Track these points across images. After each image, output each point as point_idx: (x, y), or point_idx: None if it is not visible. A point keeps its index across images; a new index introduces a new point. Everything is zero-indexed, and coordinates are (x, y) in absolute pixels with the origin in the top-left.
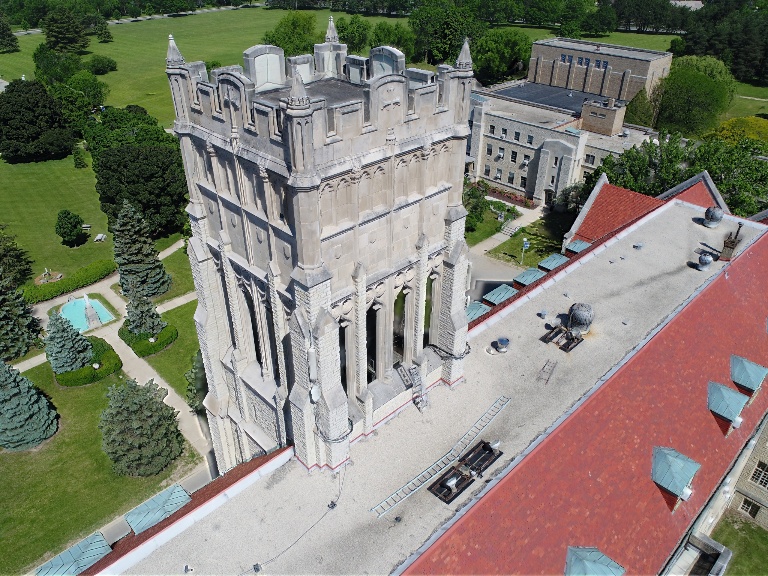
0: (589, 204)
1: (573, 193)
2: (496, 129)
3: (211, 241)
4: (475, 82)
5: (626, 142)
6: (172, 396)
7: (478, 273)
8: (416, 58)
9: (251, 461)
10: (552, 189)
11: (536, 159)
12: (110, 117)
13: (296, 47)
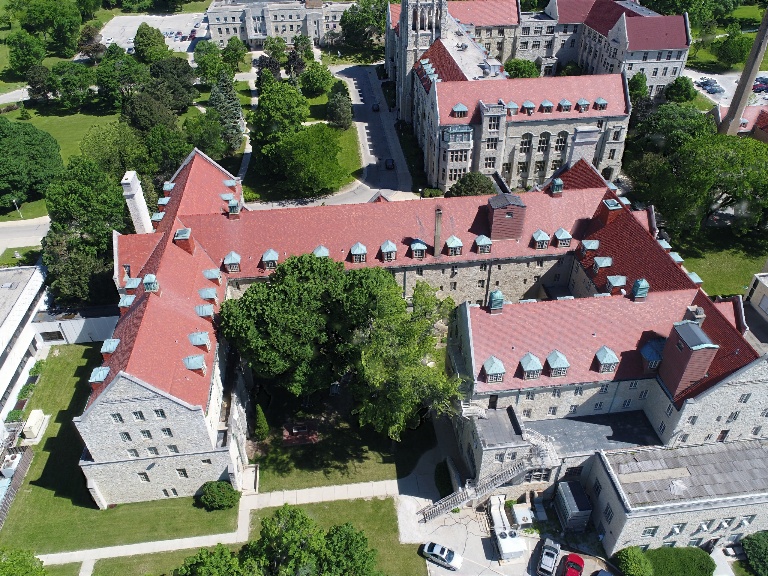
0: (390, 12)
1: (330, 34)
2: (278, 17)
3: (413, 2)
4: (224, 2)
5: (331, 8)
6: (315, 122)
7: (331, 71)
8: (95, 7)
9: (423, 55)
10: (317, 37)
11: (304, 25)
12: (68, 67)
13: (69, 8)
